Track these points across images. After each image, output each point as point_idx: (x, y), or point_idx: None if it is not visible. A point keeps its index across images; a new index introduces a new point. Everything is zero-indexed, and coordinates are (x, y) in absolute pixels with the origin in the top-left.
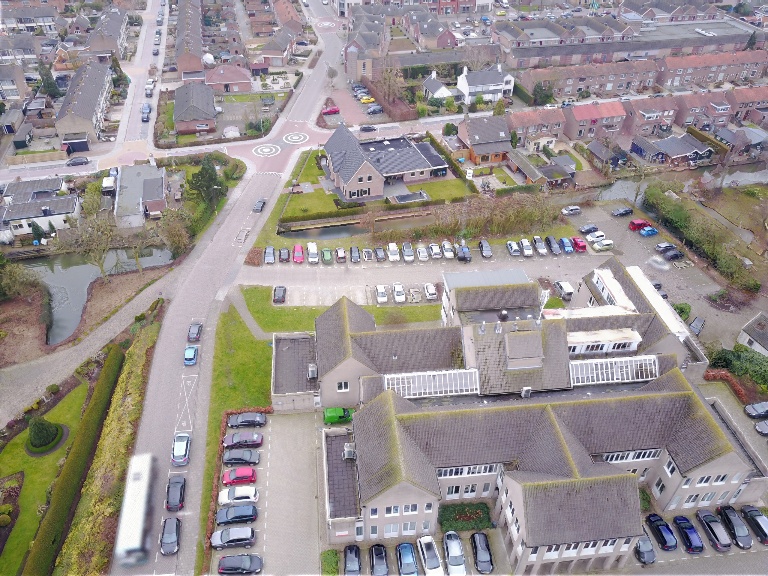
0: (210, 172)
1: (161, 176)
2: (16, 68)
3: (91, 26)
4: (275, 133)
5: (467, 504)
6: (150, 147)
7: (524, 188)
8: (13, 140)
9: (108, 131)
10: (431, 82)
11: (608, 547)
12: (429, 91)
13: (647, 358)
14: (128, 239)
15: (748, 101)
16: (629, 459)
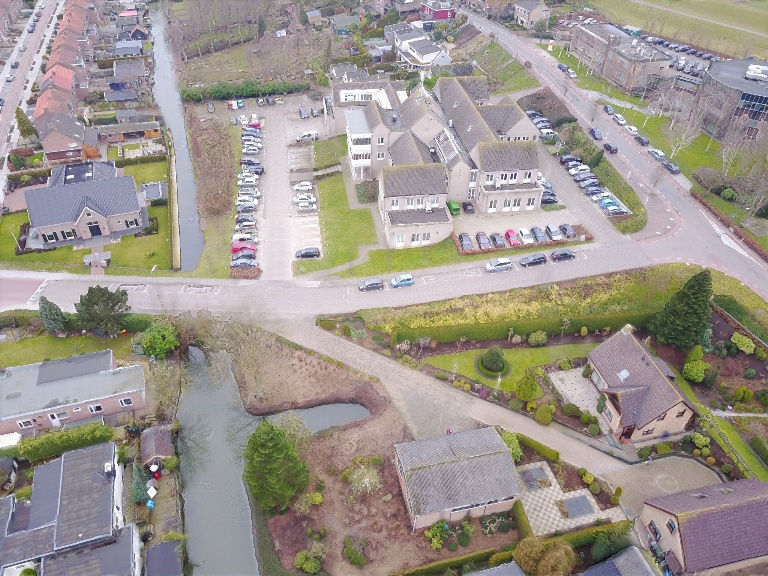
0: (98, 287)
1: (39, 365)
2: None
3: None
4: None
5: None
6: None
7: None
8: None
9: None
10: None
11: None
12: None
13: None
14: None
15: (81, 30)
16: None
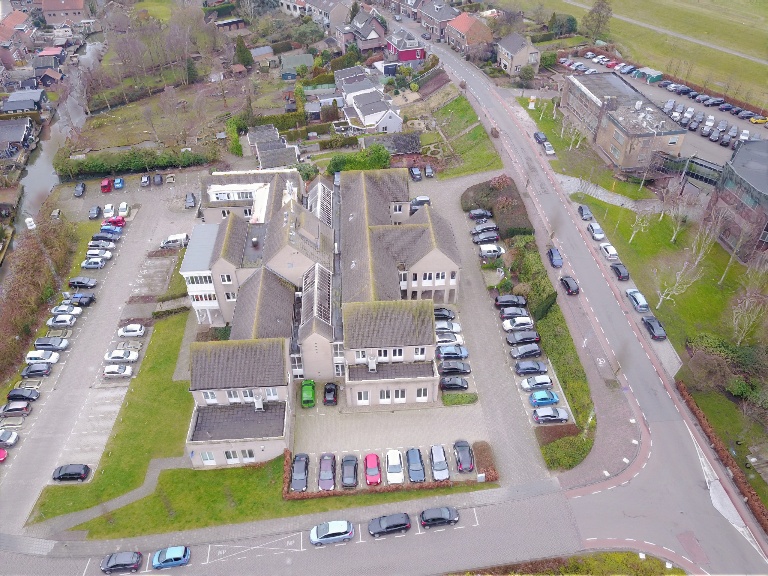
0: None
1: None
2: None
3: None
4: None
5: None
6: None
7: None
8: None
9: None
10: None
11: None
12: None
13: (320, 186)
14: None
15: None
16: None
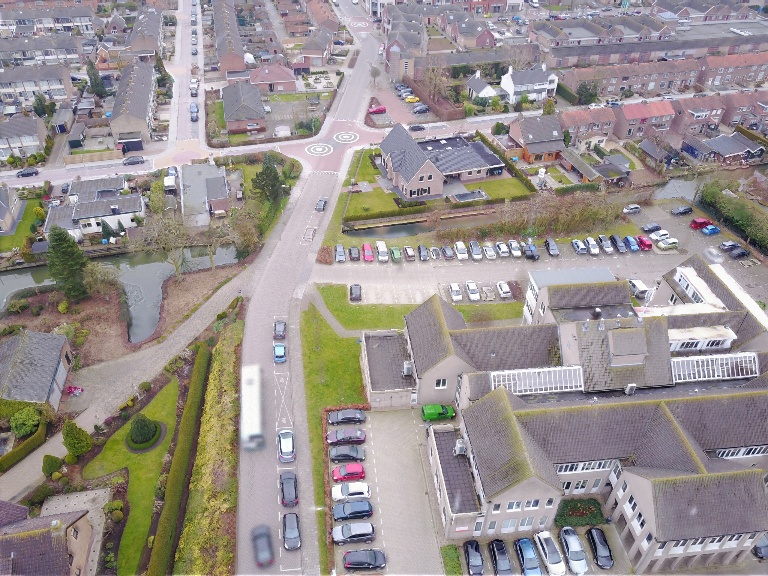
0: (274, 171)
1: (222, 175)
2: (63, 68)
3: (127, 26)
4: (325, 132)
5: (577, 500)
6: (203, 146)
7: (582, 187)
8: (68, 139)
9: (159, 130)
10: (475, 81)
11: (732, 542)
12: (473, 90)
13: (747, 355)
14: (195, 238)
15: None
16: (739, 455)
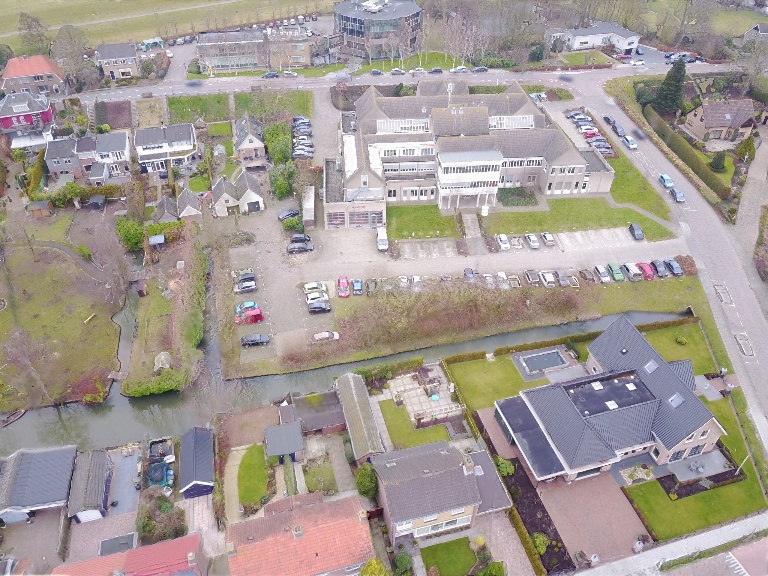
0: None
1: None
2: None
3: None
4: None
5: None
6: None
7: None
8: None
9: None
10: None
11: None
12: None
13: (382, 120)
14: None
15: None
16: None
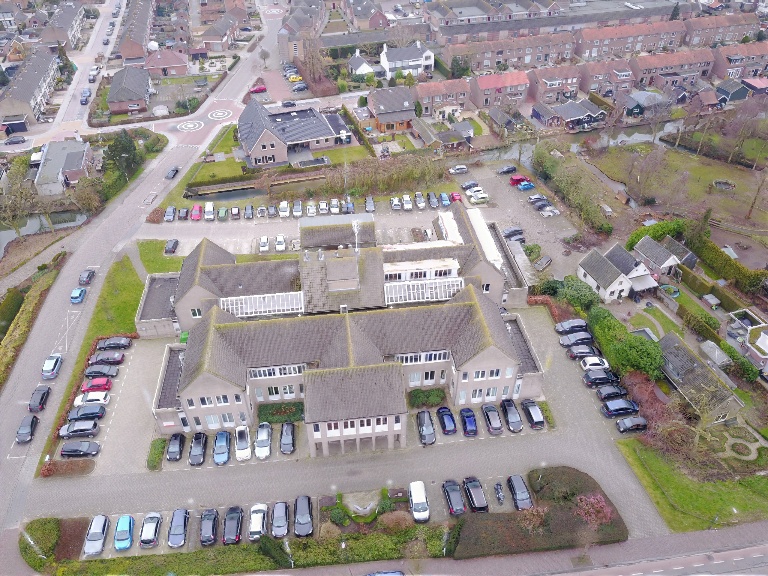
0: (123, 143)
1: (83, 149)
2: None
3: None
4: (202, 111)
5: (286, 403)
6: (84, 126)
7: (418, 151)
8: None
9: (48, 113)
10: (355, 60)
11: (383, 426)
12: (353, 68)
13: (454, 280)
14: None
15: (651, 67)
16: (423, 361)
